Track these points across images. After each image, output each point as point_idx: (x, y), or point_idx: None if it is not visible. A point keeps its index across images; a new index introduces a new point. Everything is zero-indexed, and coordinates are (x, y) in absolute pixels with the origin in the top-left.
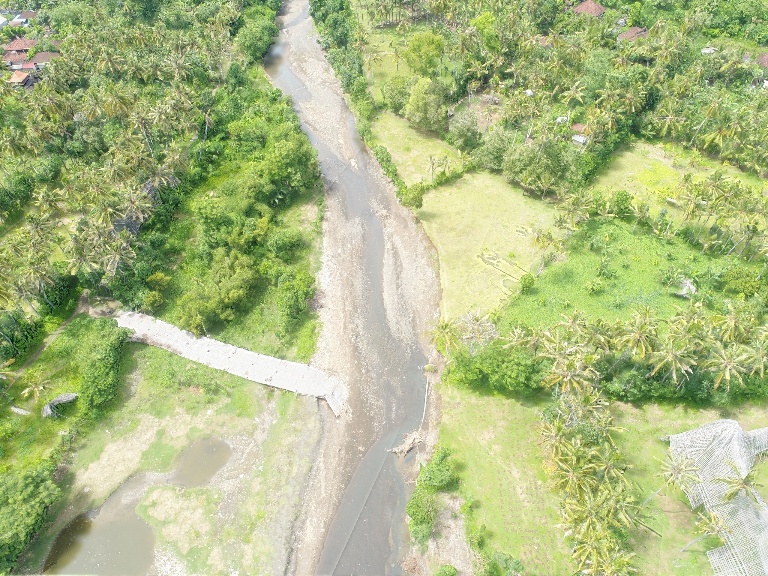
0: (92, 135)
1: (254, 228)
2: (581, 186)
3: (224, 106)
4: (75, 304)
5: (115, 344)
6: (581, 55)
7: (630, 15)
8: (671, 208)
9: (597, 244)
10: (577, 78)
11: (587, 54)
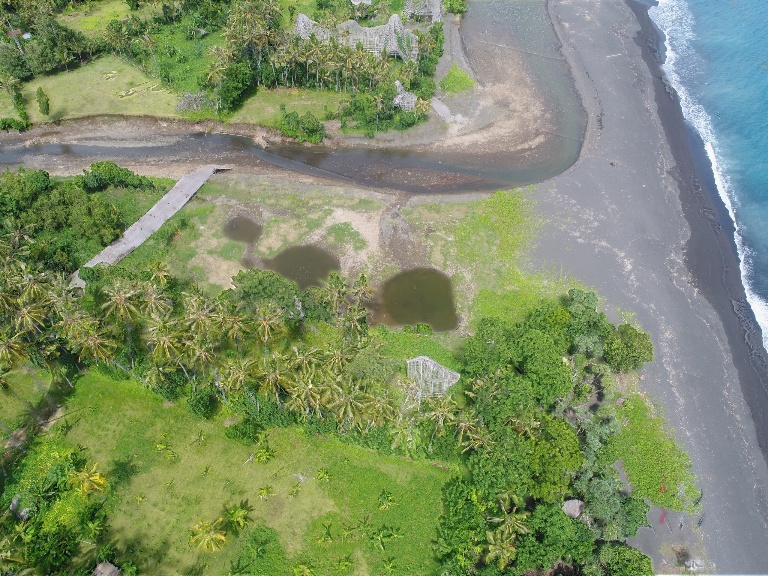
0: None
1: None
2: None
3: None
4: None
5: None
6: None
7: None
8: None
9: (146, 48)
10: None
11: None
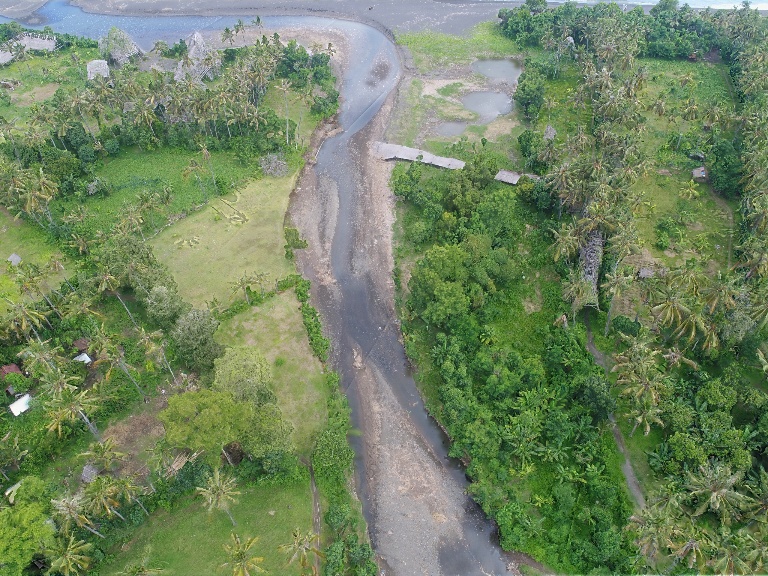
0: None
1: None
2: None
3: None
4: None
5: None
6: None
7: None
8: None
9: None
10: None
11: None
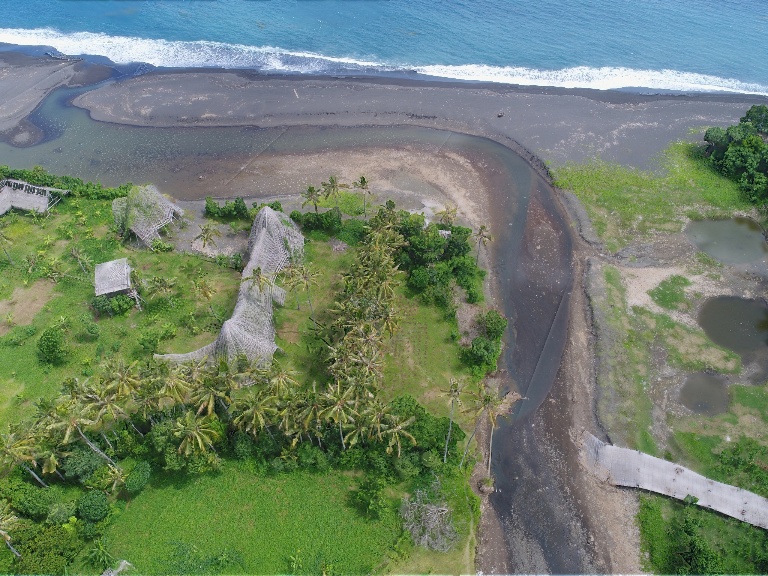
0: None
1: None
2: None
3: None
4: None
5: None
6: None
7: None
8: None
9: None
10: None
11: None
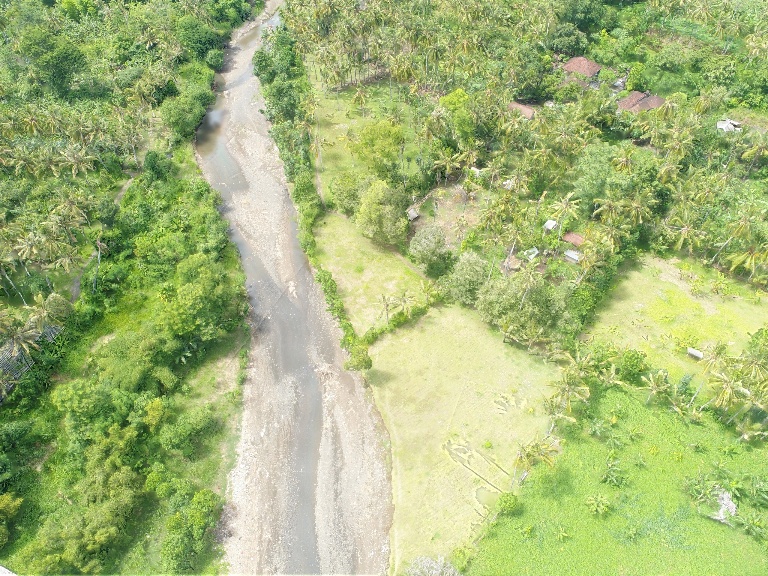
0: None
1: None
2: (577, 332)
3: (136, 208)
4: None
5: None
6: (574, 144)
7: (630, 77)
8: (693, 362)
9: (601, 431)
10: (569, 172)
11: (581, 145)
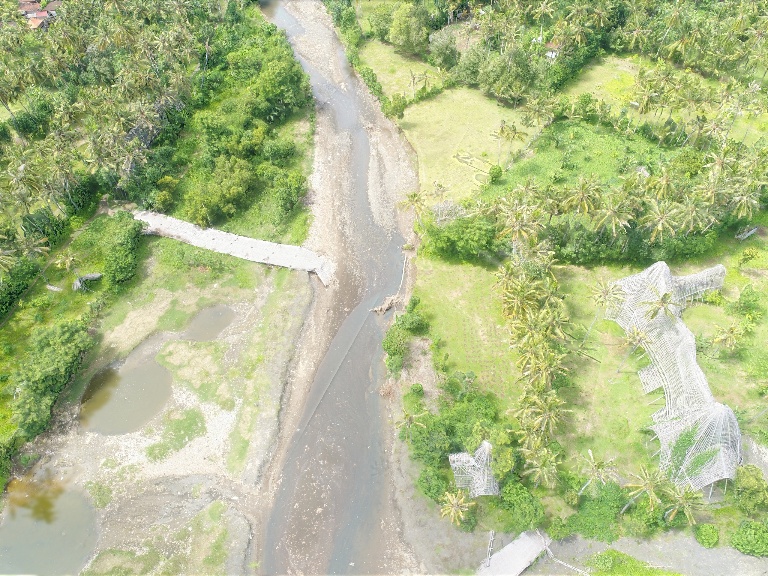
0: (104, 65)
1: (252, 139)
2: (551, 94)
3: (223, 41)
4: (96, 207)
5: (132, 234)
6: None
7: None
8: (634, 111)
9: (562, 141)
10: None
11: None
